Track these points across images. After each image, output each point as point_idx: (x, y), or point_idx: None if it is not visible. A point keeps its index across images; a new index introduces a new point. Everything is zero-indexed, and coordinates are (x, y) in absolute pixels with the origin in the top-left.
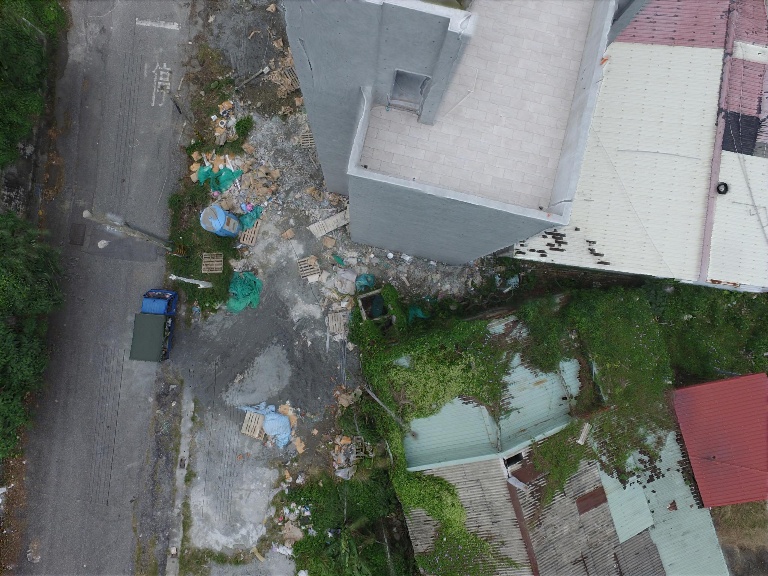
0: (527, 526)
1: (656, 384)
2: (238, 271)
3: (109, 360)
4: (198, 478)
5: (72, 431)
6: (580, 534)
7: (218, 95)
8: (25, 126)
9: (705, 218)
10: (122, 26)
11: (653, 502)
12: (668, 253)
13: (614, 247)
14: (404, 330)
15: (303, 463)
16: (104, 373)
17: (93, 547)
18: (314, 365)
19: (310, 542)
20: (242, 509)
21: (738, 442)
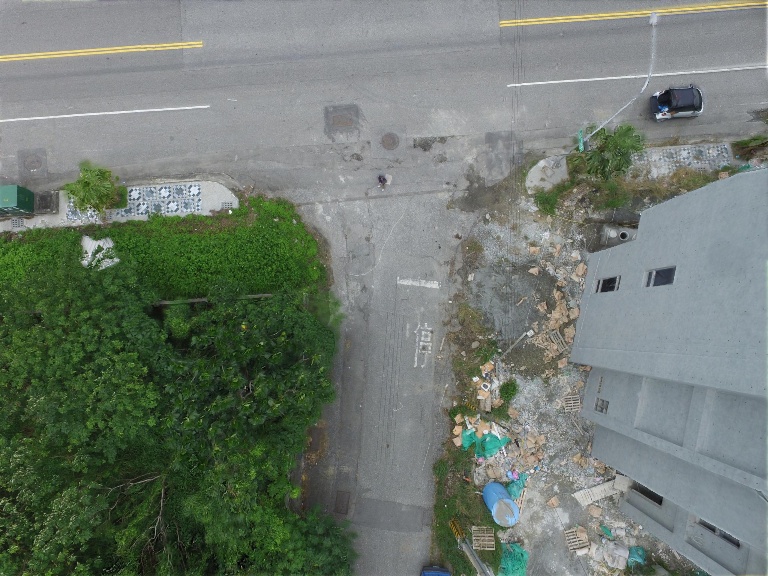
0: None
1: None
2: (504, 542)
3: None
4: None
5: None
6: None
7: (479, 356)
8: (317, 415)
9: None
10: (383, 285)
11: None
12: None
13: None
14: None
15: None
16: None
17: None
18: None
19: None
20: None
21: None
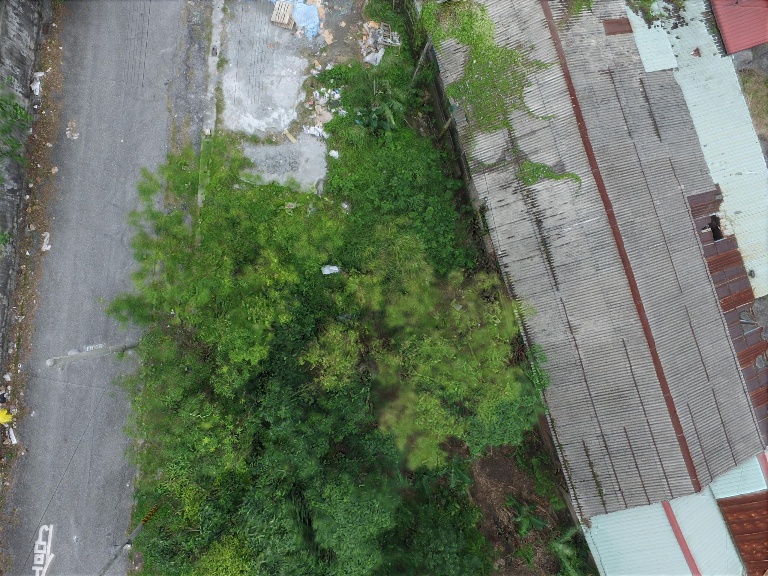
0: (556, 26)
1: None
2: None
3: None
4: (230, 65)
5: (107, 18)
6: (607, 50)
7: None
8: None
9: None
10: None
11: (677, 47)
12: None
13: None
14: None
15: (332, 54)
16: None
17: (130, 124)
18: None
19: (340, 117)
20: (273, 94)
21: None
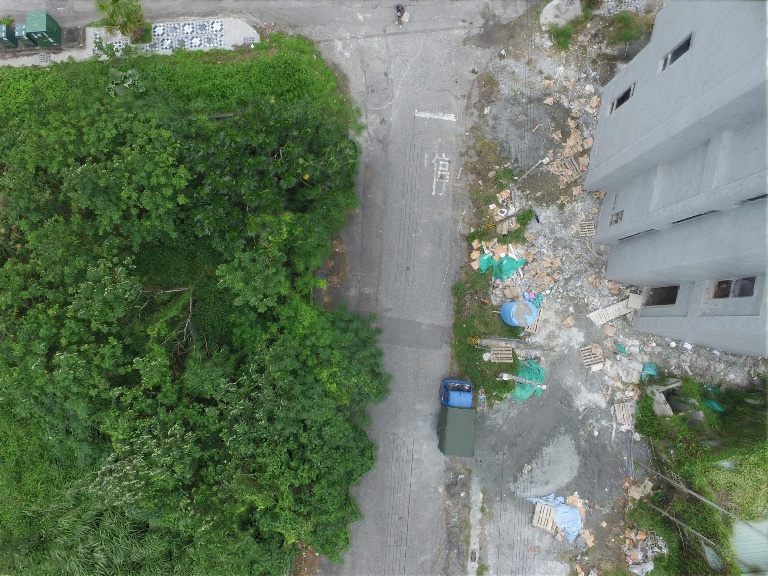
0: None
1: None
2: (521, 359)
3: (399, 449)
4: (490, 572)
5: (365, 522)
6: None
7: (496, 184)
8: (340, 222)
9: None
10: (402, 117)
11: None
12: None
13: None
14: (716, 427)
15: (593, 557)
16: (395, 463)
17: None
18: (600, 455)
19: None
20: None
21: None
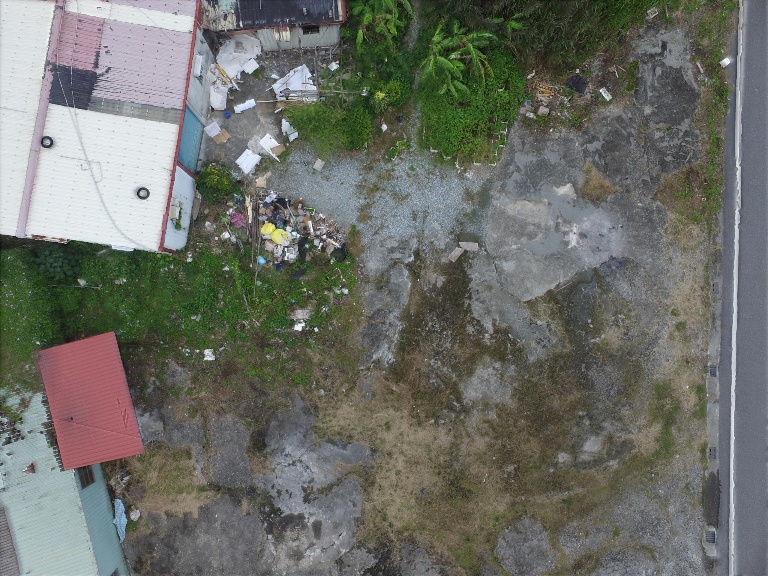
0: None
1: (22, 345)
2: None
3: None
4: None
5: None
6: None
7: None
8: None
9: (26, 172)
10: None
11: (6, 465)
12: None
13: None
14: None
15: None
16: None
17: None
18: None
19: None
20: None
21: (91, 402)
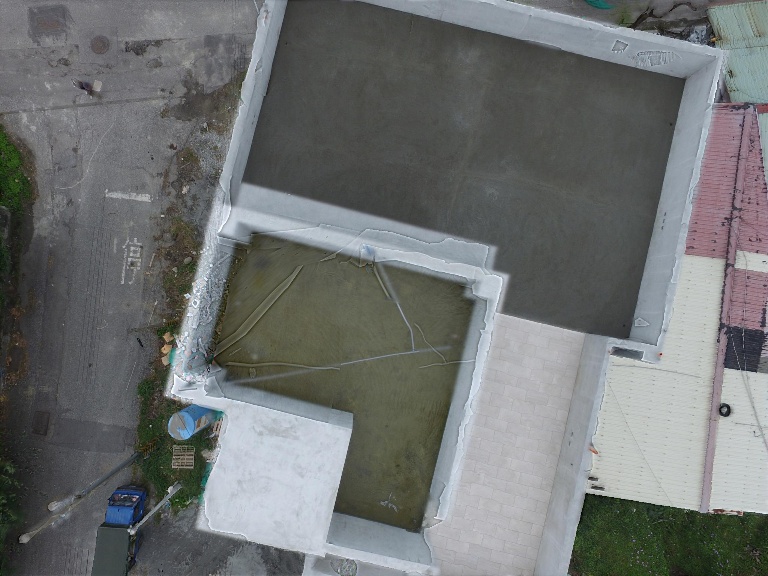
0: None
1: None
2: (211, 462)
3: (72, 561)
4: None
5: None
6: None
7: (191, 272)
8: None
9: (706, 443)
10: (91, 198)
11: None
12: (667, 479)
13: (609, 471)
14: None
15: None
16: (67, 575)
17: None
18: (291, 563)
19: None
20: None
21: None
